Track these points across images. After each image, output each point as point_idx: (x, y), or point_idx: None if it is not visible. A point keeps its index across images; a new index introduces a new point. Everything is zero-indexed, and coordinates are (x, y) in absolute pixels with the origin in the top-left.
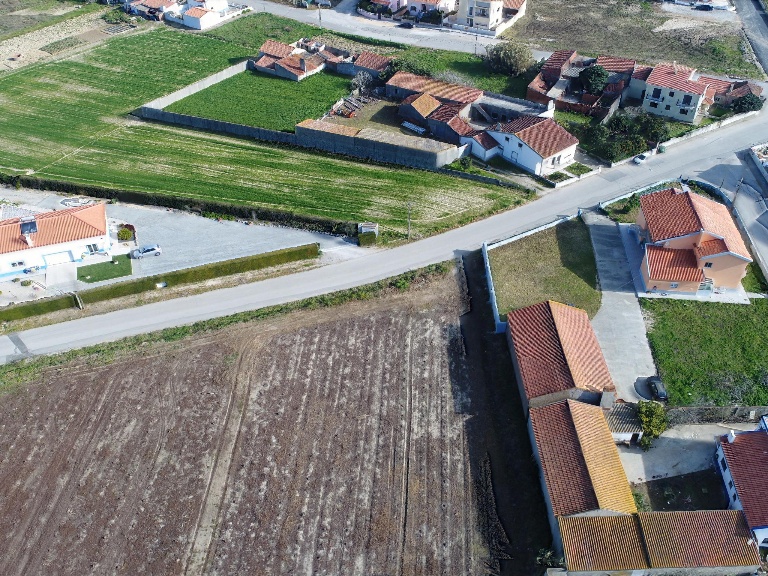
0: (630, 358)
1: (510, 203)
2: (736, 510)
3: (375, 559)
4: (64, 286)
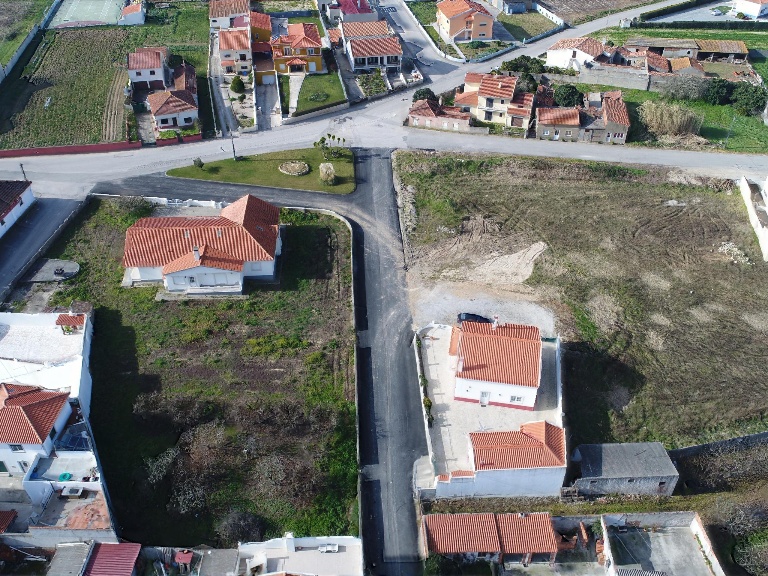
0: None
1: None
2: None
3: None
4: (729, 4)
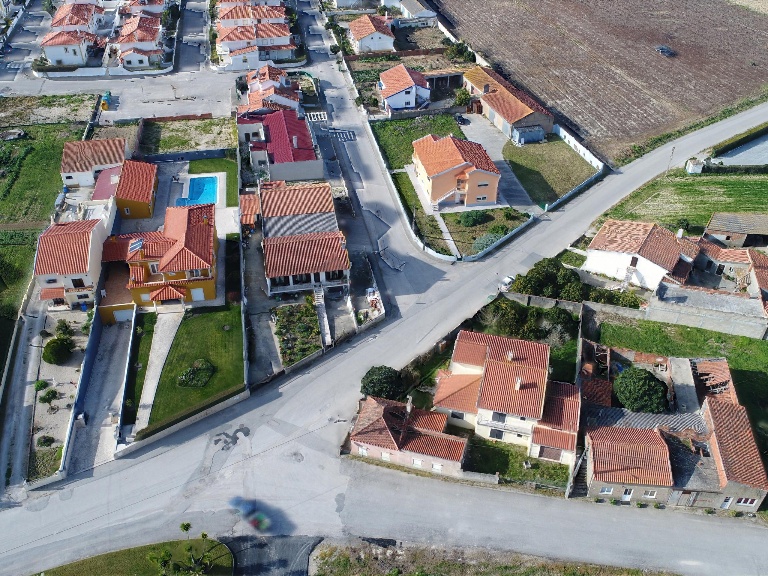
0: (477, 131)
1: (613, 212)
2: (426, 76)
3: (553, 74)
4: None
